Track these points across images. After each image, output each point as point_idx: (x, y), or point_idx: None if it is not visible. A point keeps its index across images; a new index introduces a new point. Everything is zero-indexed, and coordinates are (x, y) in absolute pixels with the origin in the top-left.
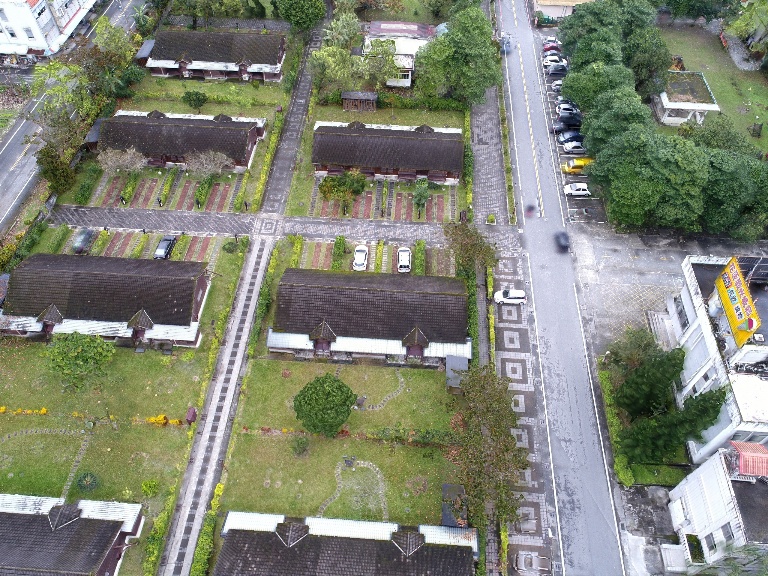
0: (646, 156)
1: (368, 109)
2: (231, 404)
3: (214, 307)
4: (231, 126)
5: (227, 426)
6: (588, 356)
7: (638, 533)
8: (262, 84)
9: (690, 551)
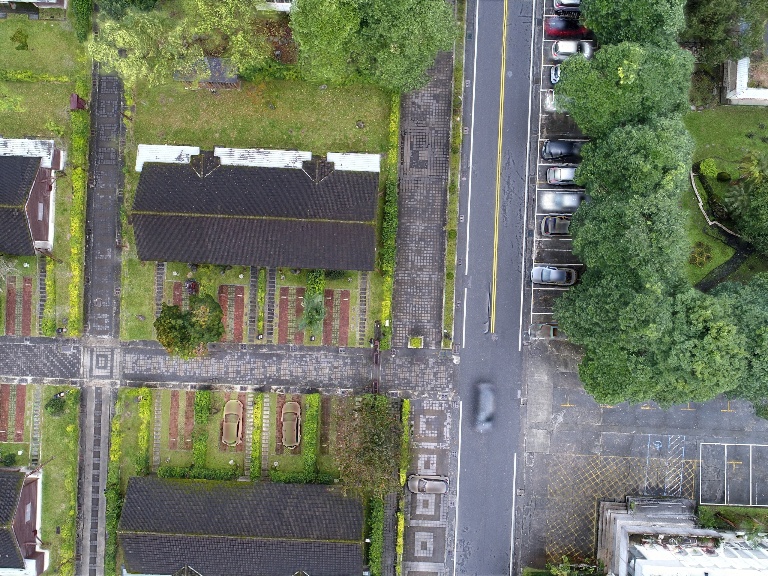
0: (650, 346)
1: (226, 87)
2: None
3: (54, 507)
4: None
5: None
6: (513, 566)
7: None
8: (36, 15)
9: None
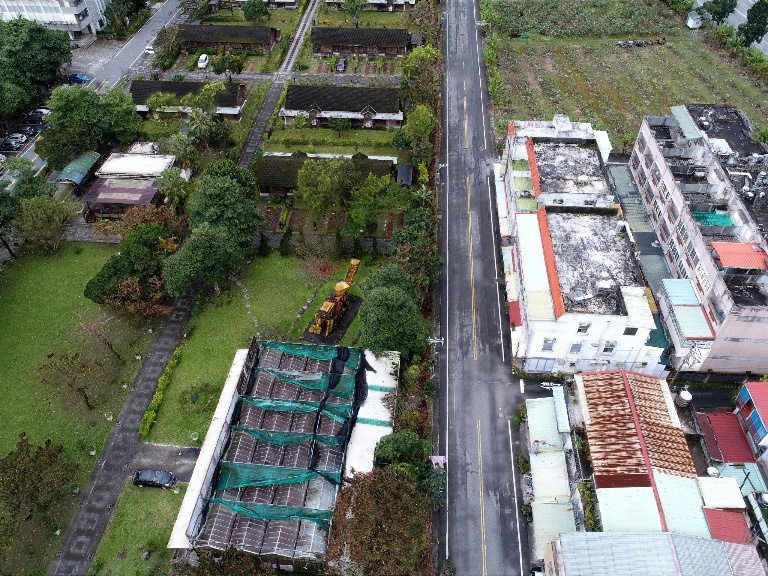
0: None
1: None
2: None
3: None
4: (302, 91)
5: None
6: None
7: (153, 8)
8: None
9: None
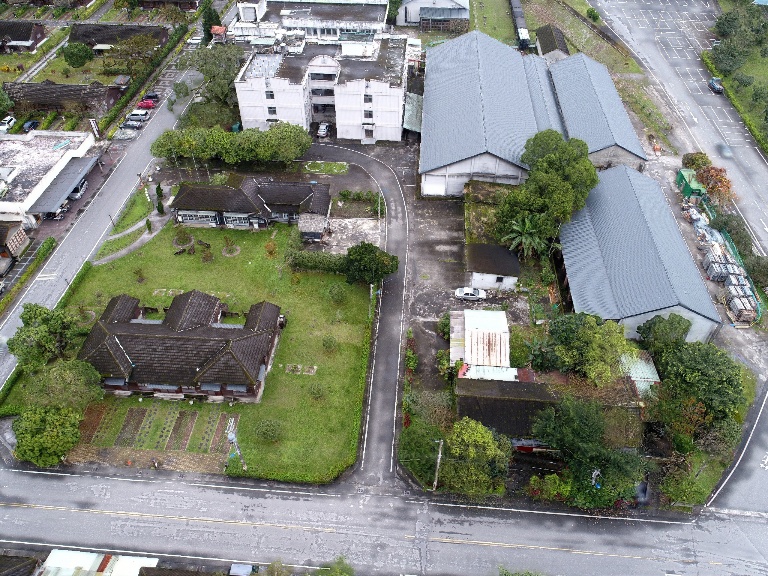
0: None
1: None
2: (42, 68)
3: None
4: None
5: (37, 73)
6: None
7: None
8: None
9: (209, 82)
